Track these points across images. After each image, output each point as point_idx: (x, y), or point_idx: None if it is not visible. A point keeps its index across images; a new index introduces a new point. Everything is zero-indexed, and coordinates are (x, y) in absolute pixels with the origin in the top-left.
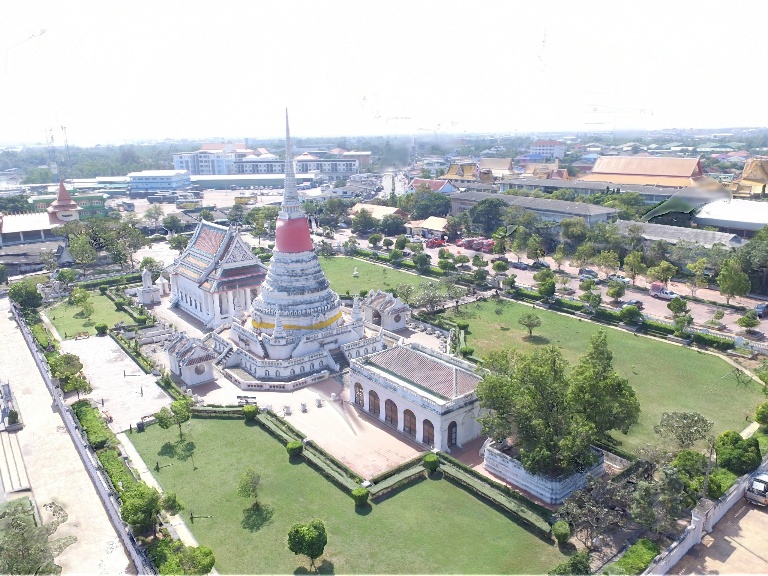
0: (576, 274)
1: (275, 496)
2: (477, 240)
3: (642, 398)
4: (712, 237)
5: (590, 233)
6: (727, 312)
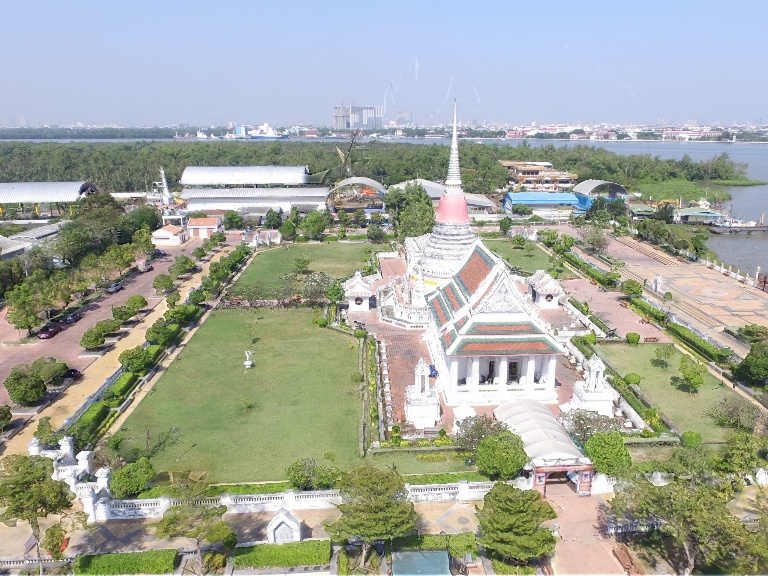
0: None
1: (521, 257)
2: None
3: None
4: None
5: None
6: (164, 259)
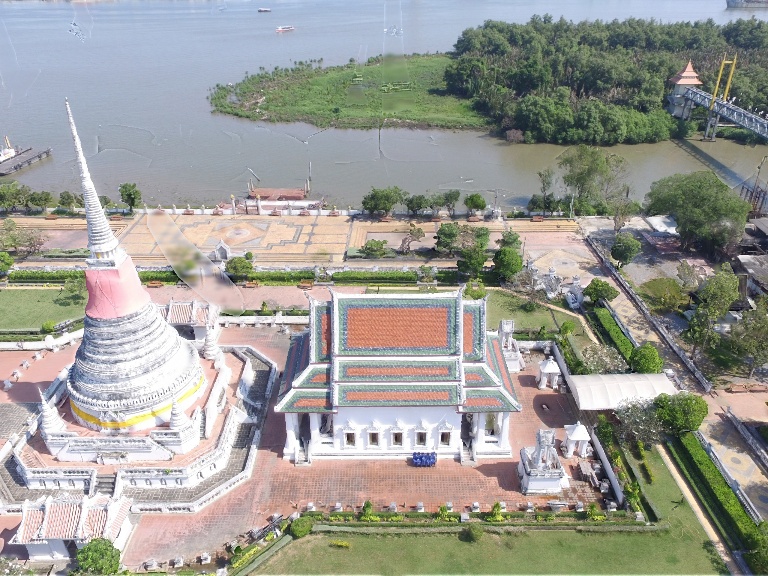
0: None
1: None
2: None
3: None
4: None
5: None
6: None
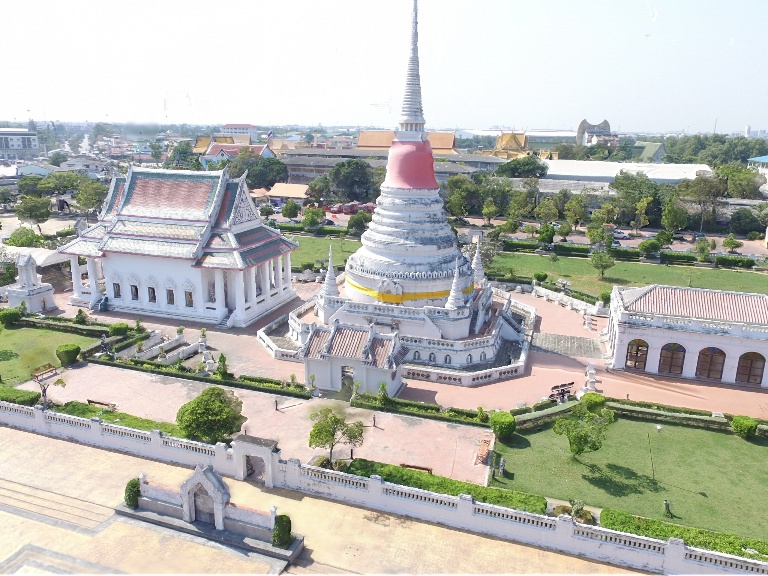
0: None
1: None
2: (356, 205)
3: None
4: (592, 186)
5: (483, 189)
6: (678, 243)
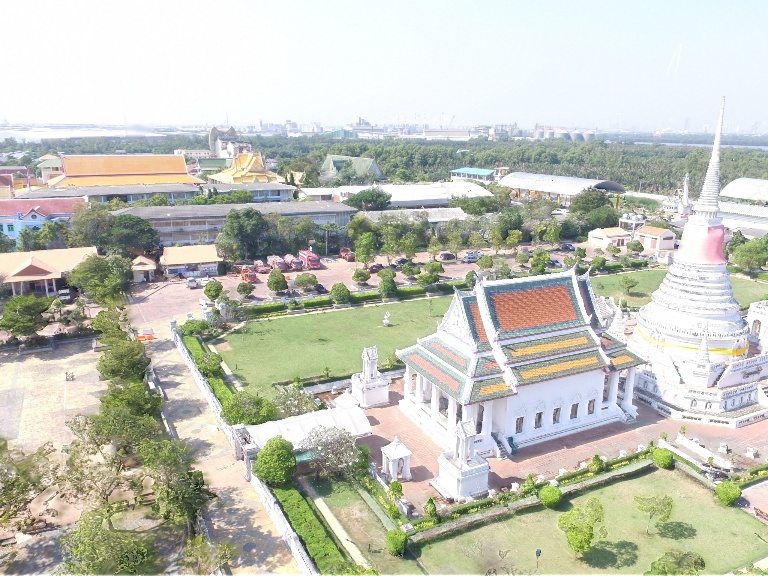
0: (443, 260)
1: None
2: None
3: (740, 291)
4: (452, 212)
5: None
6: (564, 253)
